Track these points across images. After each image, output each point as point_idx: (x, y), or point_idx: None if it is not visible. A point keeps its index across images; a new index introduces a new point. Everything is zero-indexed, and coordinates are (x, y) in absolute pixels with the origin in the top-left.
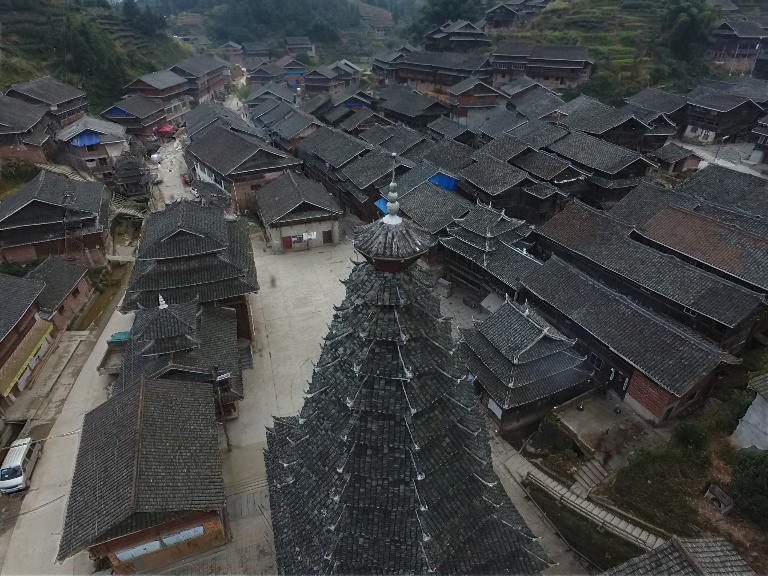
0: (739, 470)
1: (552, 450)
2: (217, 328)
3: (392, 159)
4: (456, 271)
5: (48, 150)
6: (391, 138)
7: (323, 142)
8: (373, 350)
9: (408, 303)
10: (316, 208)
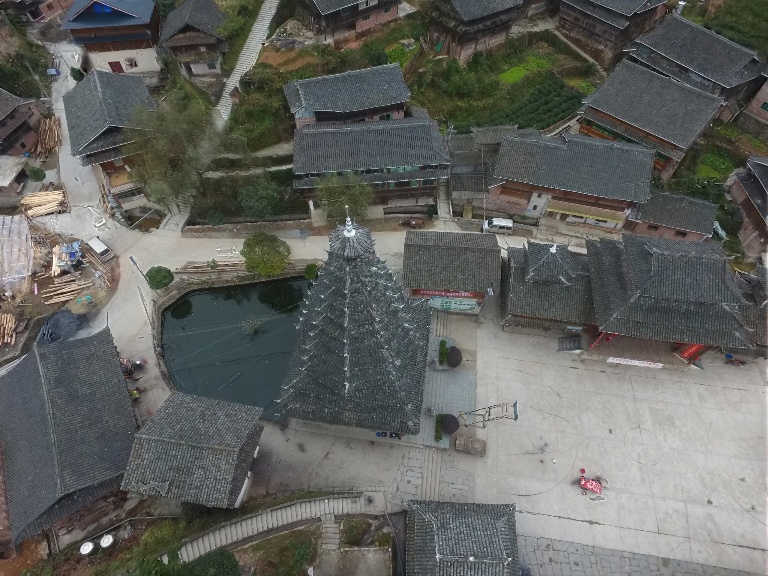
0: (235, 568)
1: (373, 541)
2: (567, 304)
3: None
4: None
5: None
6: None
7: None
8: None
9: None
10: None
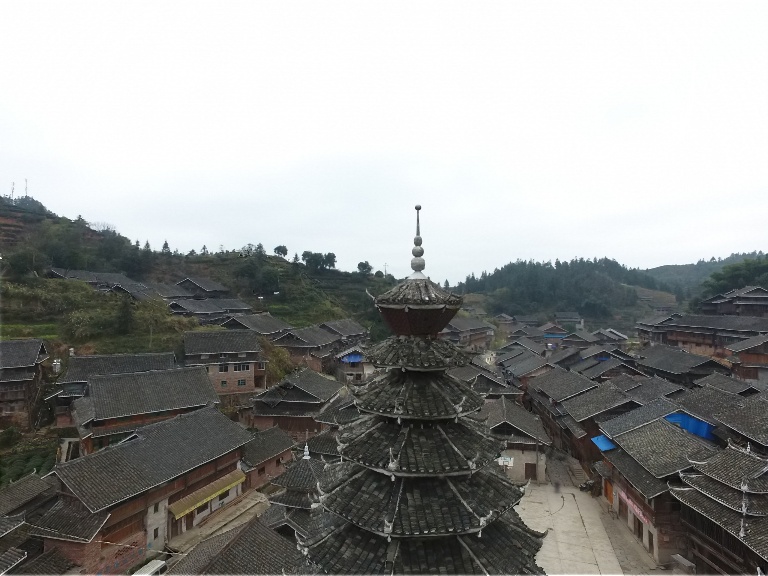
0: None
1: None
2: None
3: (621, 394)
4: (701, 545)
5: (326, 364)
6: (638, 387)
7: (551, 379)
8: (371, 434)
9: (413, 369)
10: (520, 433)
